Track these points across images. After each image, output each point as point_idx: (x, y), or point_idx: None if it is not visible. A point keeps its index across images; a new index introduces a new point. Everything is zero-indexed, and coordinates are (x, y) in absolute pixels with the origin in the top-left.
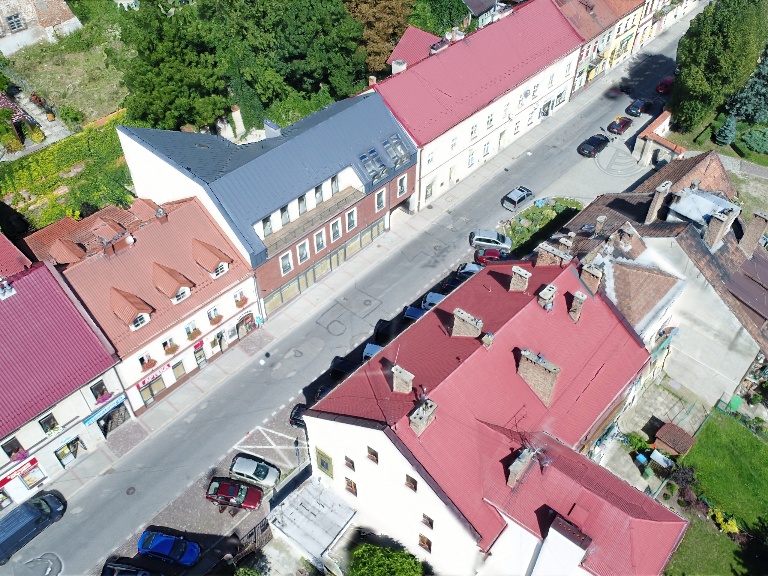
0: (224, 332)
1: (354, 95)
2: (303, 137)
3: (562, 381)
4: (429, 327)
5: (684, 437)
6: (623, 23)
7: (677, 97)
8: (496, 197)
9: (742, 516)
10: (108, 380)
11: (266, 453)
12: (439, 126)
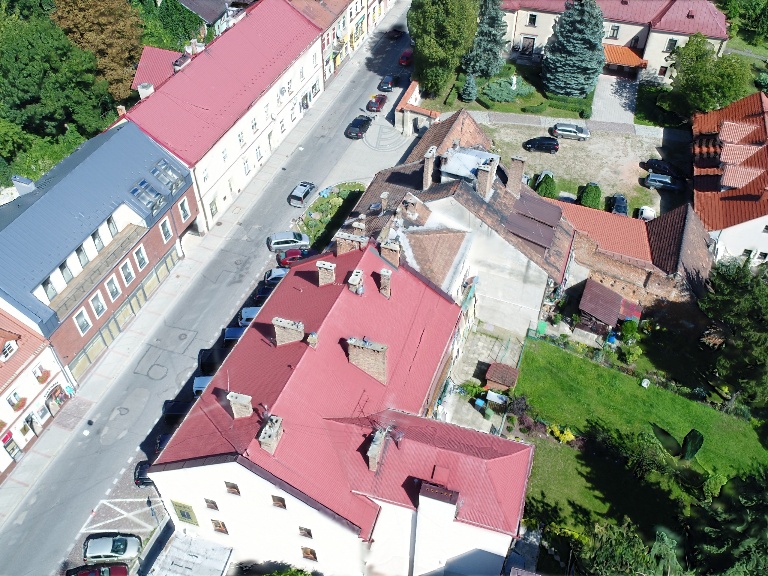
0: (33, 414)
1: (106, 129)
2: (62, 185)
3: (392, 356)
4: (252, 344)
5: (509, 371)
6: (353, 7)
7: (419, 67)
8: (281, 198)
9: (574, 424)
10: None
11: (119, 525)
12: (205, 142)
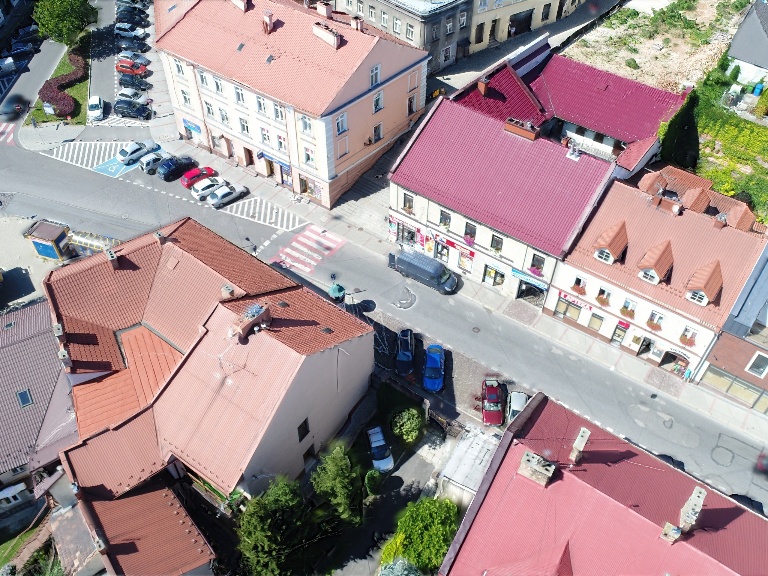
0: (654, 344)
1: None
2: None
3: None
4: None
5: None
6: None
7: None
8: None
9: None
10: (548, 264)
11: None
12: None
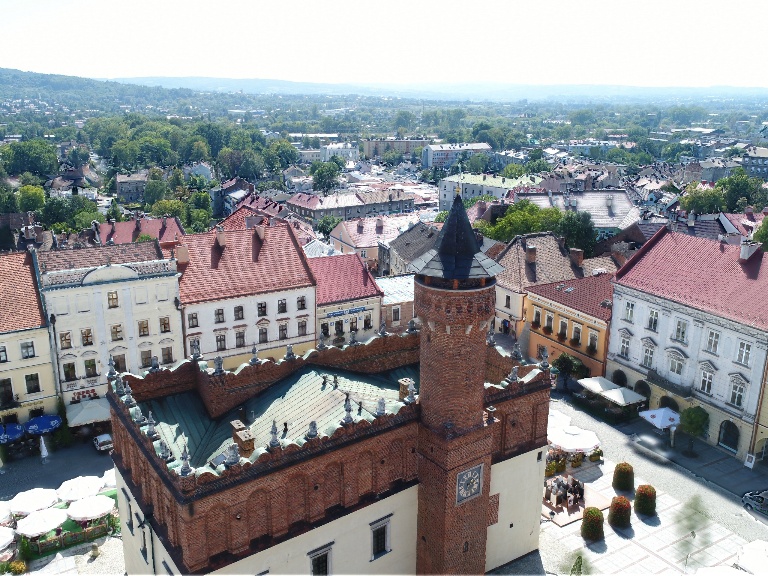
0: None
1: None
2: None
3: None
4: None
5: None
6: None
7: None
8: None
9: None
10: None
11: None
12: None
